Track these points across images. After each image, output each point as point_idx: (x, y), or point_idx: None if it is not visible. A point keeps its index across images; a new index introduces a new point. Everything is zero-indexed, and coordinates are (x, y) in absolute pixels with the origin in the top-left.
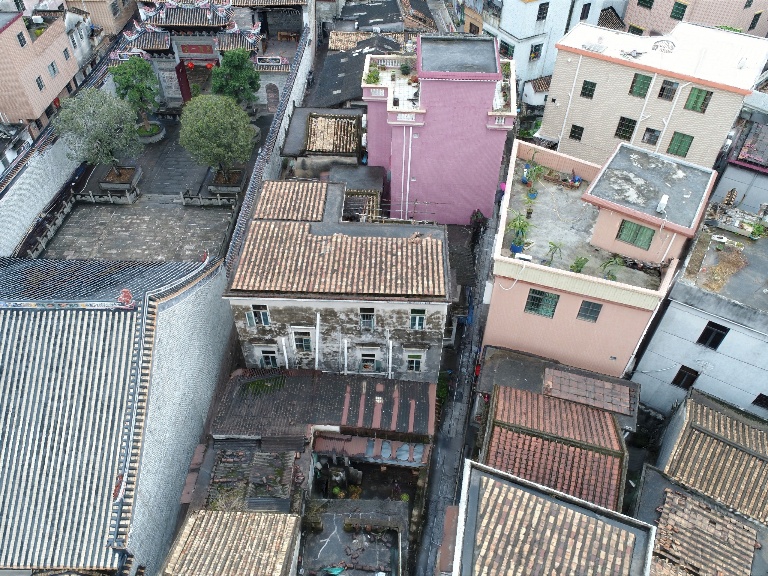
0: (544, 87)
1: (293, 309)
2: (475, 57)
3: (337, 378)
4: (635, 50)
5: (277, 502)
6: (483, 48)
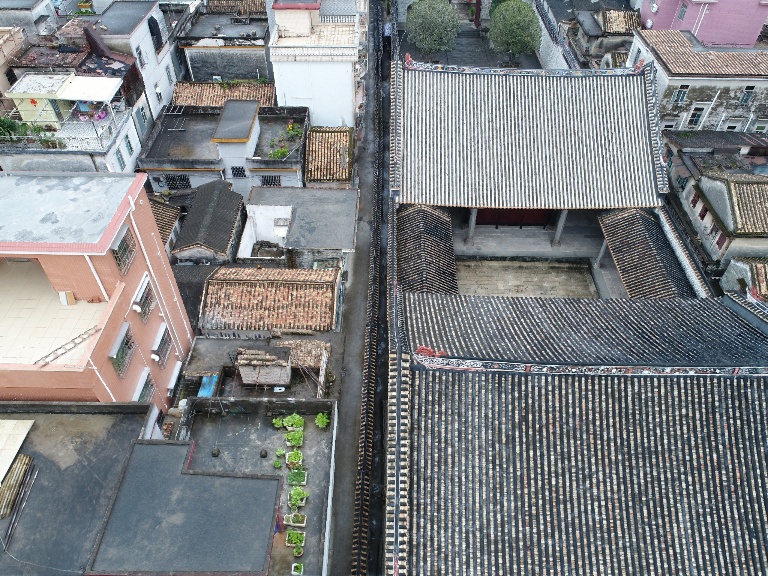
0: None
1: (704, 88)
2: None
3: (728, 132)
4: None
5: (744, 171)
6: None
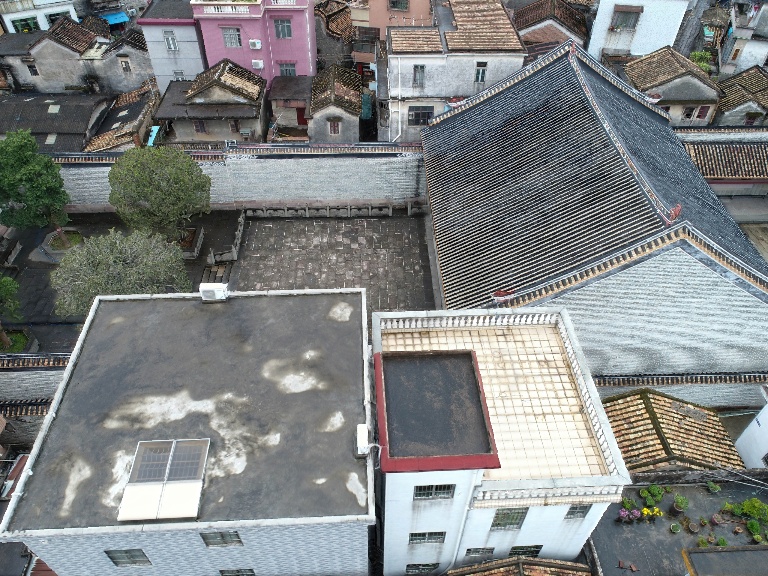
0: (106, 34)
1: None
2: None
3: None
4: None
5: (620, 72)
6: None
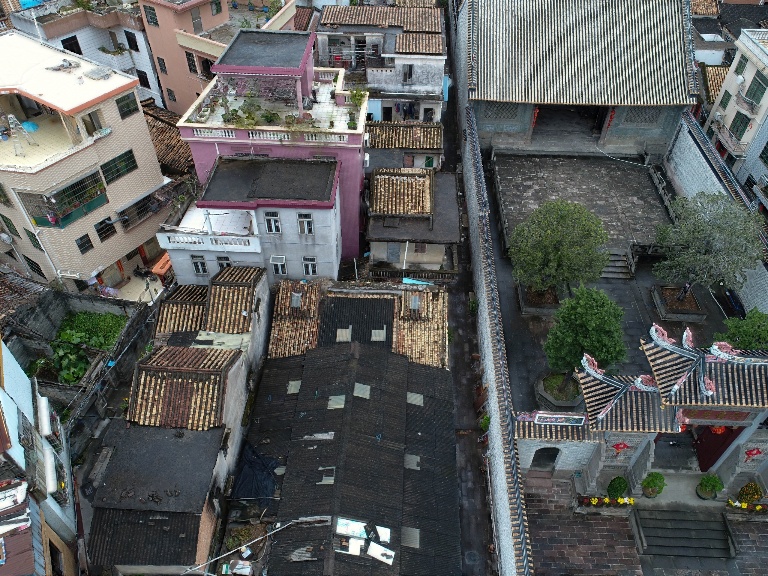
0: None
1: None
2: (250, 50)
3: None
4: (63, 61)
5: None
6: (234, 60)
